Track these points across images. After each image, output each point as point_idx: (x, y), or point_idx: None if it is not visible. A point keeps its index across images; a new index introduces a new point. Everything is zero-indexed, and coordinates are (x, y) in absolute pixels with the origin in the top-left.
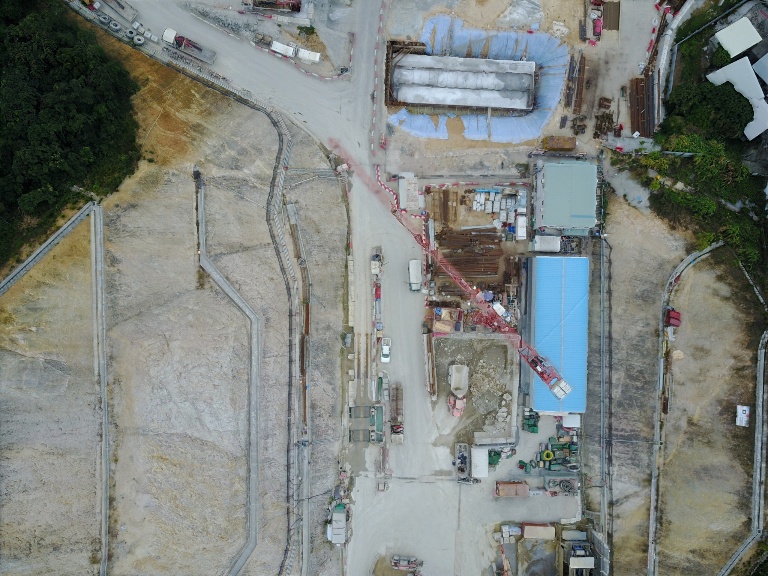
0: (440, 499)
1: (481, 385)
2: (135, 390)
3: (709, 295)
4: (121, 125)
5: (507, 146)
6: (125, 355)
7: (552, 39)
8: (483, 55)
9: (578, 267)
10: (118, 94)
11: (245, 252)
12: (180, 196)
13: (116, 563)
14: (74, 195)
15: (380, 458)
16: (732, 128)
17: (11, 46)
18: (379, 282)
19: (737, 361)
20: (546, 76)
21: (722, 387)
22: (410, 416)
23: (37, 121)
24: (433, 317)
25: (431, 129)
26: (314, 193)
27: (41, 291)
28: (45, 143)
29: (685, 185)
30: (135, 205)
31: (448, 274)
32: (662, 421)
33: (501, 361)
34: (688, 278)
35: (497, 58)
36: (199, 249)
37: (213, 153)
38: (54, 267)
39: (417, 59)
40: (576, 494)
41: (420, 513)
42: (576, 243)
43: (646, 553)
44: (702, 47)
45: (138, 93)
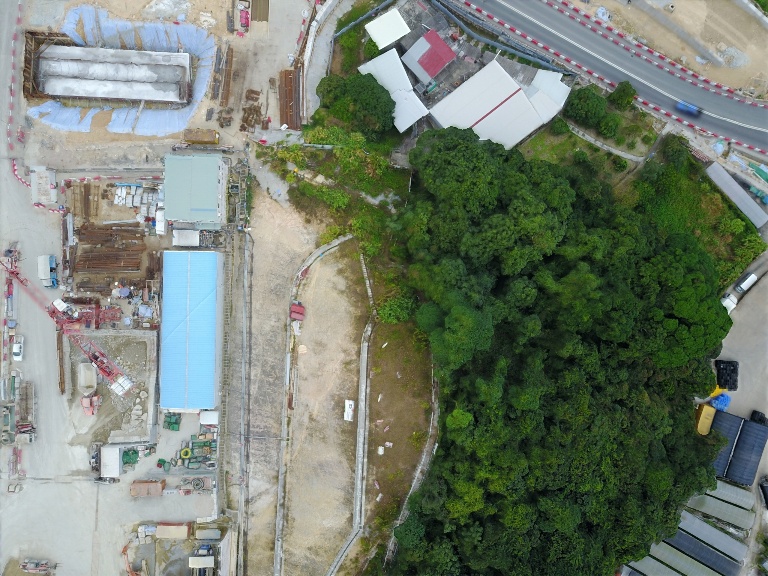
0: (77, 500)
1: None
2: None
3: (329, 289)
4: None
5: (152, 139)
6: None
7: (199, 30)
8: (139, 47)
9: (205, 261)
10: None
11: None
12: None
13: None
14: None
15: (13, 459)
16: (370, 120)
17: None
18: (12, 278)
19: (346, 355)
20: (199, 68)
21: (335, 381)
22: (46, 415)
23: None
24: None
25: (74, 122)
26: None
27: None
28: None
29: (326, 178)
30: None
31: (86, 270)
32: (289, 417)
33: (140, 358)
34: (314, 272)
35: (154, 50)
36: None
37: None
38: None
39: (66, 51)
40: (210, 492)
41: (55, 514)
42: (224, 237)
43: (273, 551)
44: (361, 39)
45: None
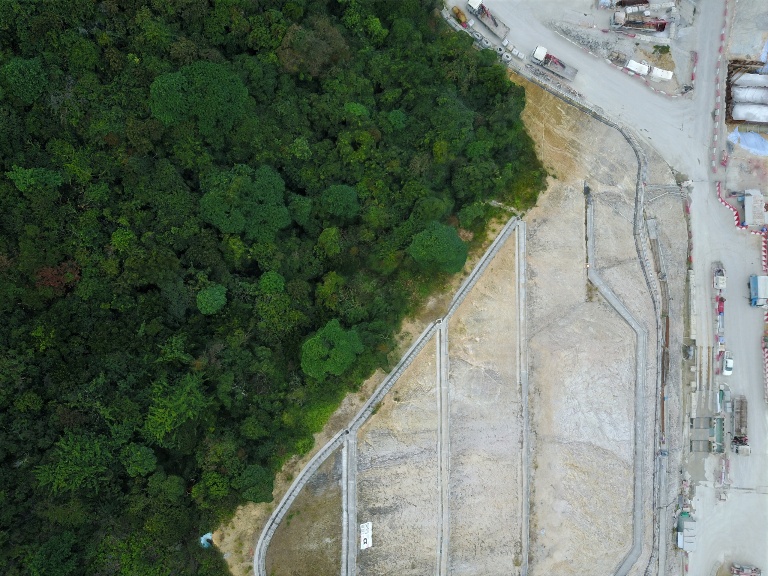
0: None
1: None
2: (553, 400)
3: None
4: (521, 141)
5: None
6: (545, 366)
7: None
8: None
9: None
10: None
11: (619, 266)
12: (574, 211)
13: (535, 566)
14: (500, 210)
15: (720, 468)
16: None
17: (439, 65)
18: (722, 297)
19: None
20: None
21: None
22: (749, 428)
23: (474, 138)
24: None
25: (767, 147)
26: (666, 209)
27: (483, 303)
28: (483, 160)
29: None
30: (546, 220)
31: None
32: None
33: None
34: None
35: None
36: (587, 263)
37: (593, 169)
38: (491, 280)
39: (750, 78)
40: None
41: (758, 523)
42: None
43: None
44: None
45: (524, 110)
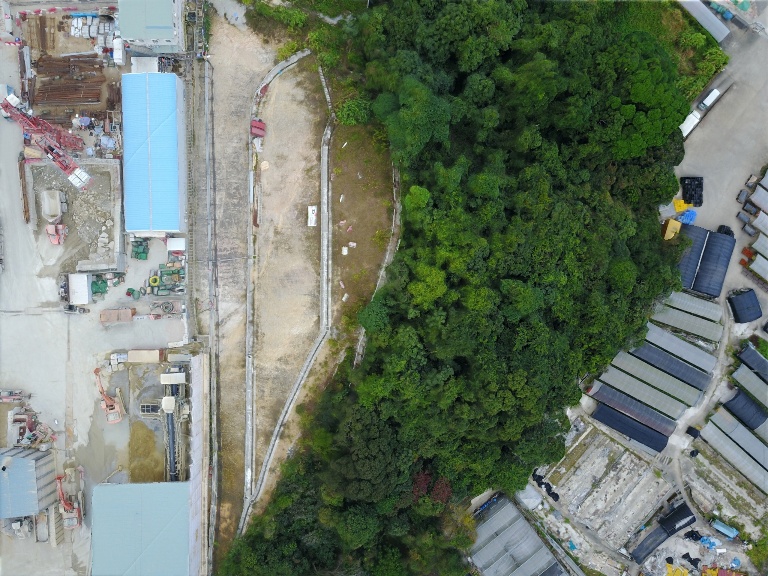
0: (48, 331)
1: (80, 211)
2: None
3: (289, 101)
4: None
5: None
6: None
7: None
8: None
9: (164, 82)
10: None
11: None
12: None
13: None
14: None
15: None
16: None
17: None
18: None
19: (307, 162)
20: None
21: (297, 191)
22: (12, 248)
23: None
24: None
25: None
26: None
27: None
28: None
29: None
30: None
31: (46, 102)
32: (255, 235)
33: (104, 188)
34: (274, 88)
35: None
36: None
37: None
38: None
39: None
40: (180, 316)
41: (27, 346)
42: (184, 68)
43: (244, 368)
44: None
45: None
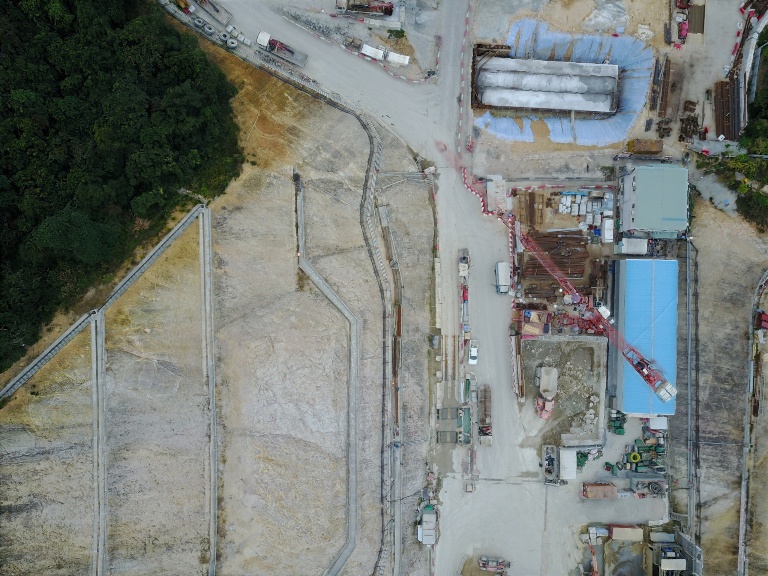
0: (527, 500)
1: (569, 387)
2: (243, 391)
3: None
4: (223, 128)
5: (592, 149)
6: (233, 356)
7: (637, 42)
8: (566, 58)
9: (668, 270)
10: (218, 97)
11: (341, 254)
12: (281, 199)
13: (224, 563)
14: (183, 198)
15: (467, 459)
16: None
17: (120, 50)
18: (466, 284)
19: None
20: (630, 79)
21: None
22: (497, 418)
23: (149, 124)
24: (521, 319)
25: (516, 132)
26: (404, 195)
27: (154, 293)
28: (157, 146)
29: None
30: (240, 207)
31: (535, 276)
32: (752, 424)
33: (588, 363)
34: None
35: (580, 61)
36: (298, 251)
37: (310, 156)
38: (166, 269)
39: (501, 62)
40: (664, 496)
41: (507, 514)
42: (661, 246)
43: (736, 555)
44: None
45: (236, 96)
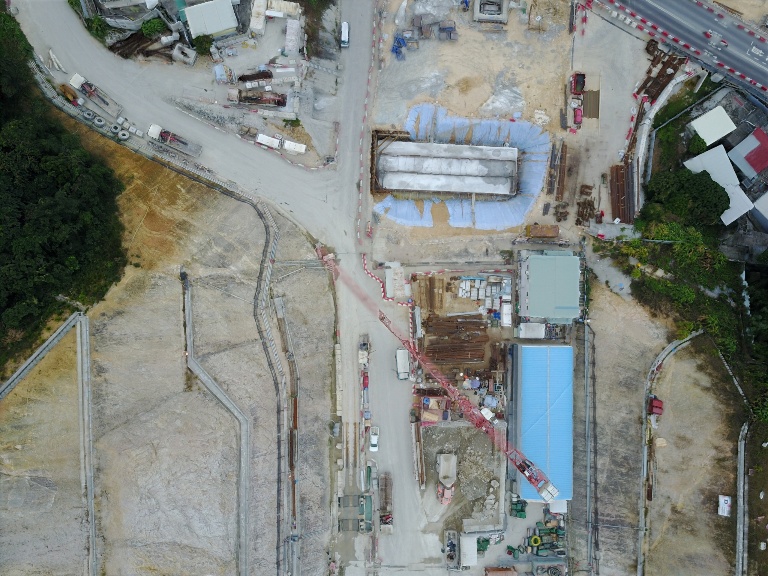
0: None
1: (469, 473)
2: (123, 502)
3: (690, 384)
4: (107, 229)
5: (491, 233)
6: (112, 467)
7: (534, 127)
8: (467, 141)
9: (563, 356)
10: (103, 196)
11: (233, 350)
12: (167, 299)
13: None
14: (60, 306)
15: (369, 547)
16: (709, 216)
17: None
18: (367, 371)
19: (718, 451)
20: (529, 162)
21: (704, 476)
22: (399, 504)
23: (22, 234)
24: (421, 406)
25: (416, 216)
26: (301, 285)
27: (26, 408)
28: (30, 256)
29: (665, 272)
30: (122, 312)
31: (435, 361)
32: (647, 507)
33: (488, 447)
34: (669, 366)
35: (480, 143)
36: (186, 351)
37: (200, 252)
38: (40, 382)
39: (402, 146)
40: None
41: None
42: (560, 328)
43: None
44: (679, 133)
45: (124, 193)
